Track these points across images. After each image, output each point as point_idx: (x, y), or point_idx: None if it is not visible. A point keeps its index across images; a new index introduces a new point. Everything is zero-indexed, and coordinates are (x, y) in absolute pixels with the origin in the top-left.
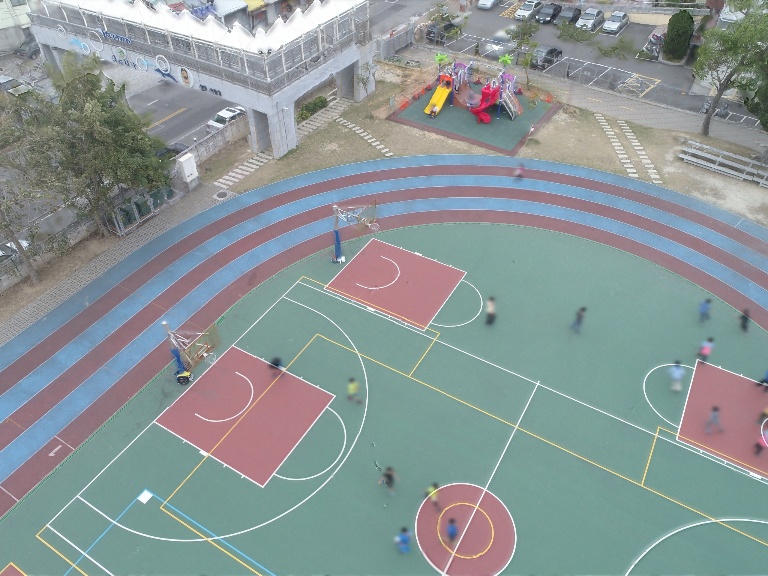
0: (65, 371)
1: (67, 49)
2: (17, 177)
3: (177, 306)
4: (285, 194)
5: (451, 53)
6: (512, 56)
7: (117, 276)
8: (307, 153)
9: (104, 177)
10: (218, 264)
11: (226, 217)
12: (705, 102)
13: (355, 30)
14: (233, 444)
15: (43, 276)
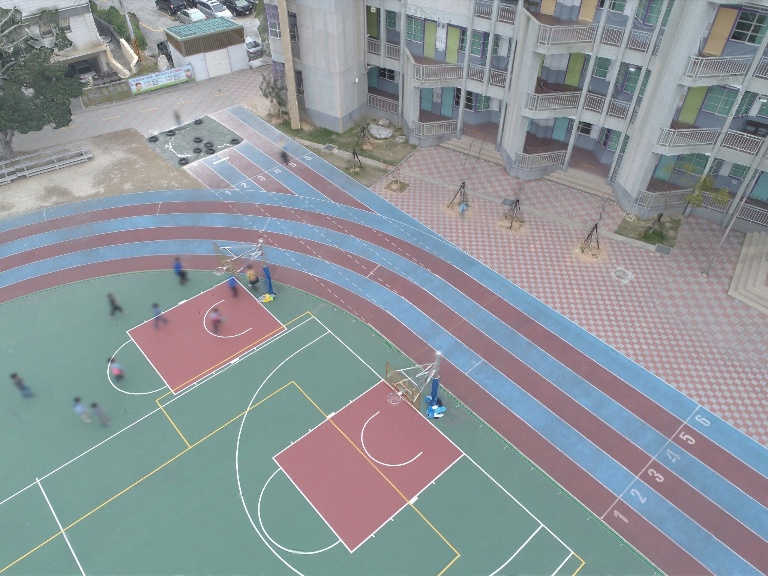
0: None
1: None
2: None
3: None
4: None
5: None
6: None
7: None
8: None
9: None
10: None
11: None
12: None
13: None
14: None
15: None
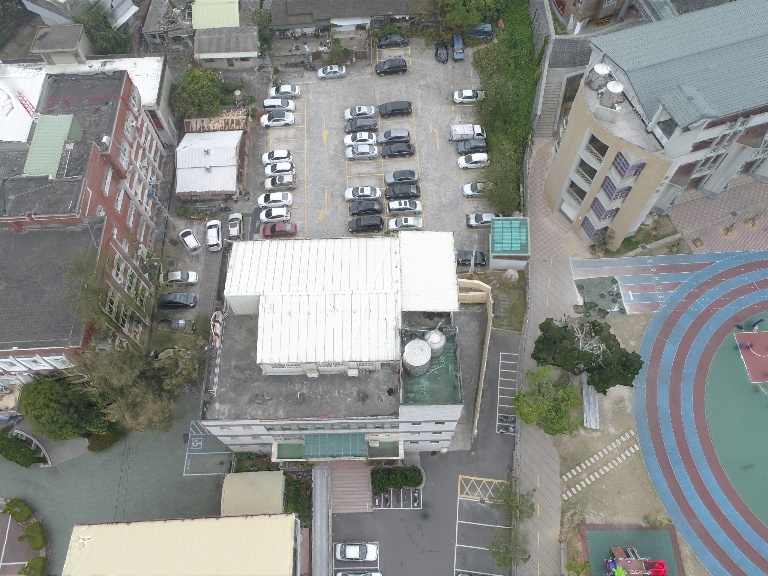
0: None
1: None
2: None
3: None
4: None
5: None
6: None
7: None
8: None
9: None
10: None
11: None
12: None
13: None
14: None
15: None
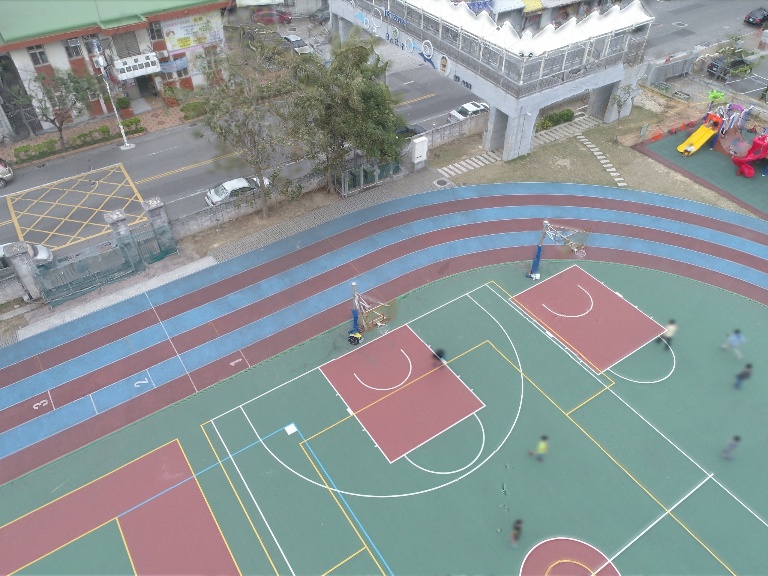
0: (264, 298)
1: (351, 21)
2: (278, 124)
3: (370, 272)
4: (501, 197)
5: (731, 92)
6: None
7: (329, 230)
8: (536, 163)
9: (345, 141)
10: (417, 245)
11: (439, 204)
12: None
13: (627, 49)
14: (377, 413)
15: (272, 213)
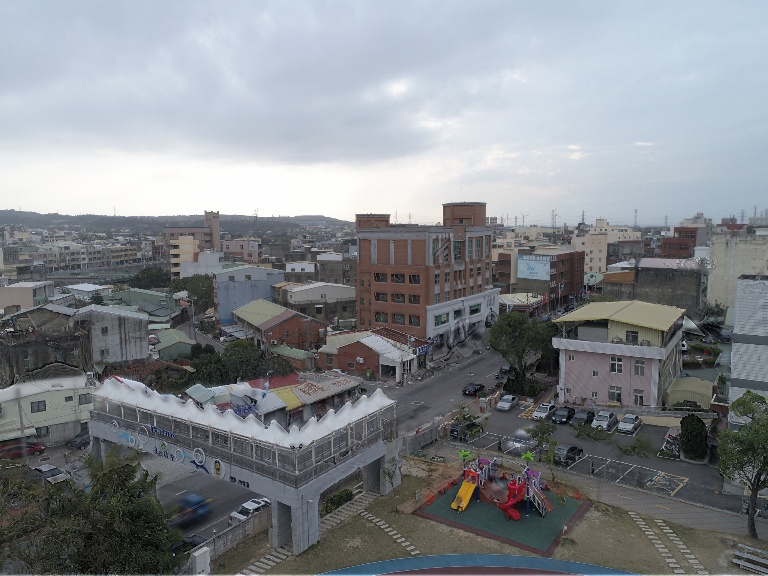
0: None
1: (115, 441)
2: (20, 570)
3: None
4: None
5: (475, 449)
6: (534, 453)
7: None
8: (328, 549)
9: (110, 572)
10: None
11: None
12: (742, 502)
13: (383, 428)
14: None
15: None
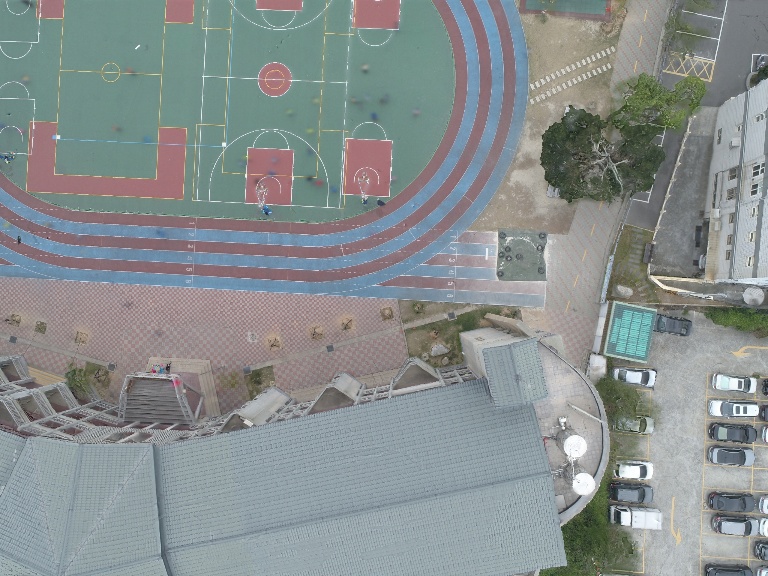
0: None
1: None
2: None
3: None
4: None
5: None
6: None
7: None
8: None
9: None
10: None
11: None
12: None
13: None
14: None
15: None
